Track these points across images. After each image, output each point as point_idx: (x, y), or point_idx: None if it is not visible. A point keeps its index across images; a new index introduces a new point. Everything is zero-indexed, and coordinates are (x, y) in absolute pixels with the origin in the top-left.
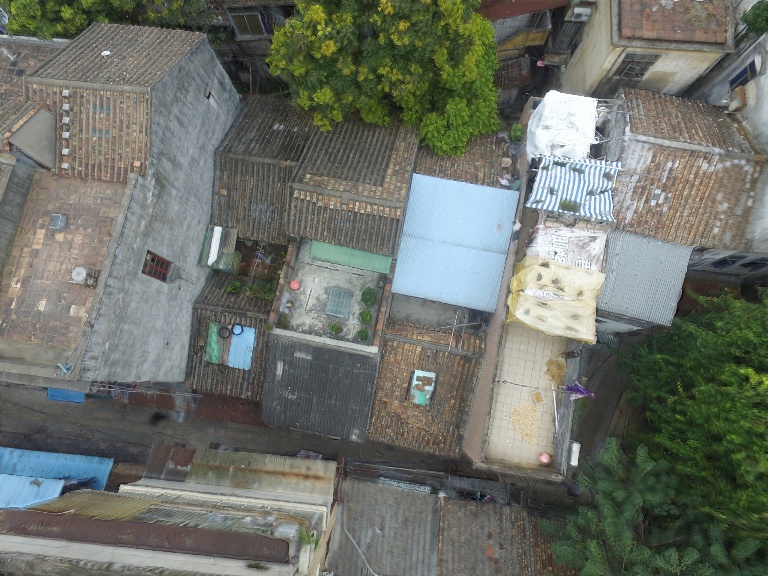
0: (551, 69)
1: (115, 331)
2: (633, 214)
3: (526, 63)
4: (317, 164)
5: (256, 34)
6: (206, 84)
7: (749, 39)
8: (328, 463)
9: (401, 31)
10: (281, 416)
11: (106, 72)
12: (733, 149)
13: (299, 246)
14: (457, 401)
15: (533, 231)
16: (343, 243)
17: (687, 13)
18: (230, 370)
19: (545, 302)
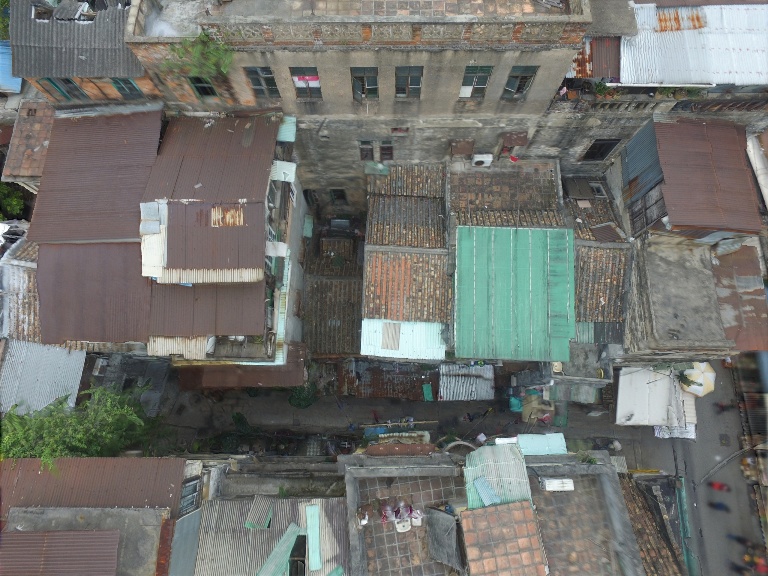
0: None
1: None
2: (28, 326)
3: None
4: None
5: None
6: None
7: None
8: None
9: None
10: None
11: None
12: None
13: None
14: None
15: None
16: None
17: None
18: None
19: None
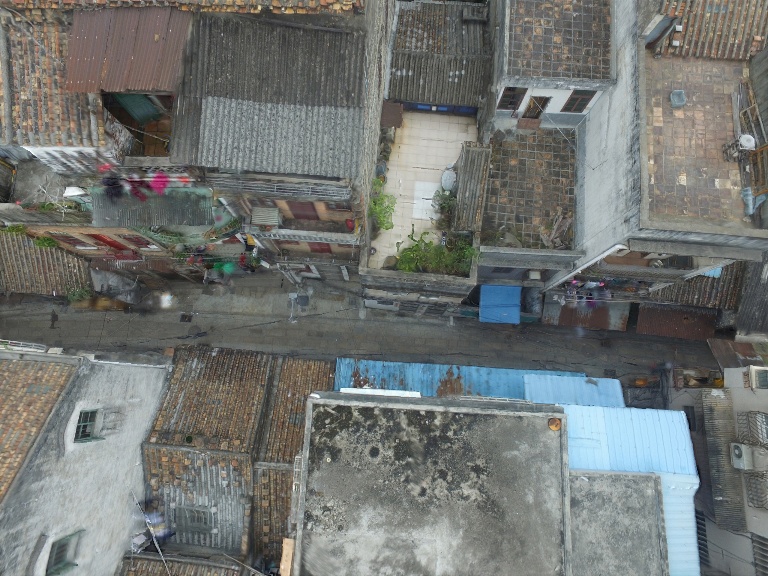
0: None
1: None
2: None
3: None
4: None
5: None
6: None
7: None
8: None
9: None
10: (758, 322)
11: None
12: None
13: None
14: None
15: None
16: None
17: None
18: (698, 279)
19: None
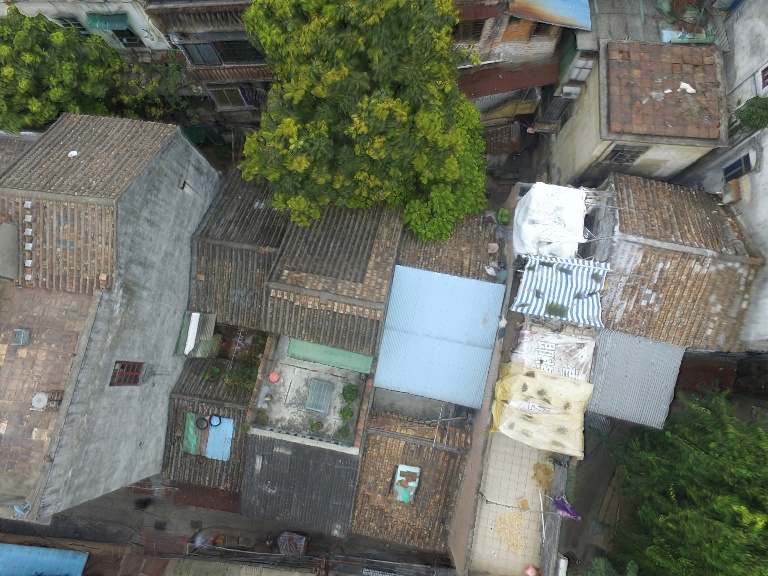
0: (541, 135)
1: (79, 455)
2: (623, 313)
3: (516, 129)
4: (296, 257)
5: (237, 105)
6: (180, 175)
7: (743, 132)
8: (306, 575)
9: (376, 148)
10: (261, 510)
11: (71, 179)
12: (727, 250)
13: (279, 335)
14: (442, 496)
15: (520, 327)
16: (322, 342)
17: (678, 106)
18: (208, 461)
19: (530, 415)
